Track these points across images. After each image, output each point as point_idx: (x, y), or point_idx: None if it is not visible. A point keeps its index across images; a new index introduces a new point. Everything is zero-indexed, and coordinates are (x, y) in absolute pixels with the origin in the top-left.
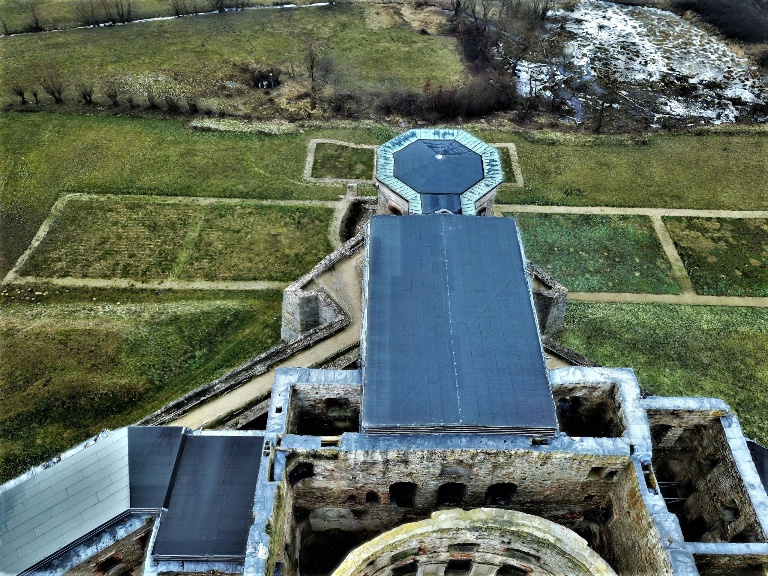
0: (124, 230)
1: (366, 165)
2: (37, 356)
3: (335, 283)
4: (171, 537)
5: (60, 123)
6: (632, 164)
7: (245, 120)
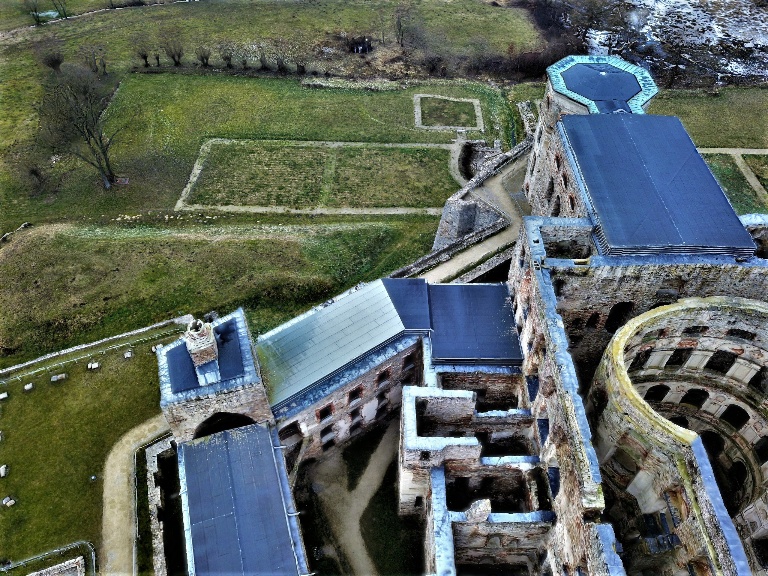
0: (269, 168)
1: (469, 115)
2: (235, 259)
3: (487, 196)
4: (443, 347)
5: (185, 82)
6: (708, 113)
7: (350, 79)
